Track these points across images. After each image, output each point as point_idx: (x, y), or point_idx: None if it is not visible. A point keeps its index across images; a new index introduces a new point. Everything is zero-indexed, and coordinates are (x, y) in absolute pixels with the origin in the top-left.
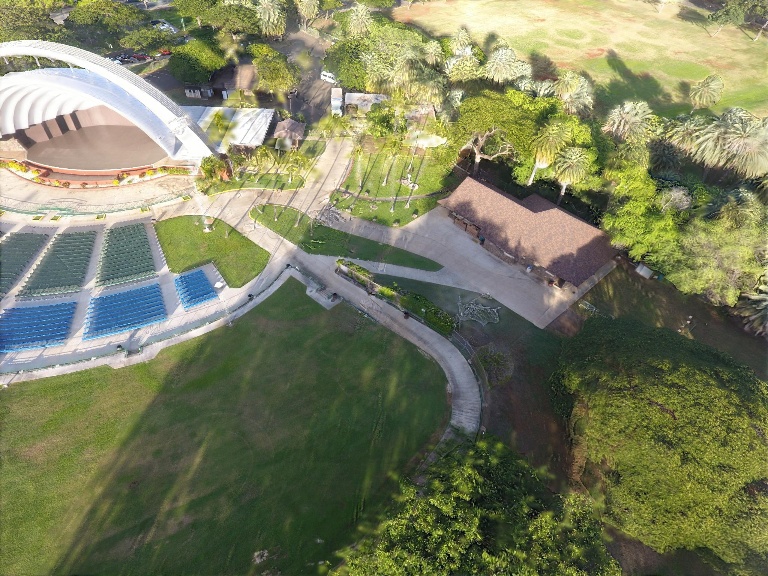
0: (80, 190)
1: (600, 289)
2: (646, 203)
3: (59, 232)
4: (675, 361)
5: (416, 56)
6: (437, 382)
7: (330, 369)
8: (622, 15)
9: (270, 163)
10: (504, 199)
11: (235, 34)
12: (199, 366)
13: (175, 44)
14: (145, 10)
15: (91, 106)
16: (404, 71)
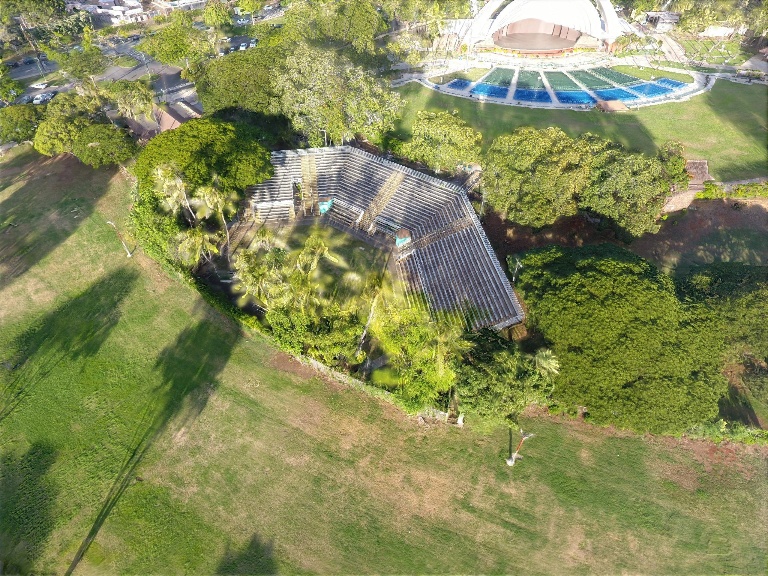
0: (546, 59)
1: None
2: None
3: (565, 72)
4: None
5: None
6: None
7: None
8: None
9: (635, 45)
10: None
11: None
12: (715, 100)
13: None
14: None
15: (518, 20)
16: None
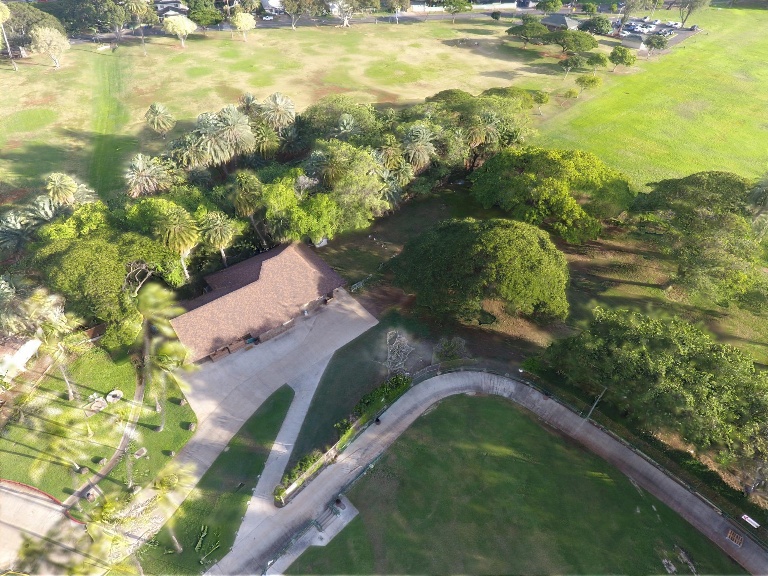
0: None
1: None
2: None
3: None
4: (470, 242)
5: None
6: (465, 402)
7: (454, 507)
8: None
9: None
10: (225, 298)
11: None
12: None
13: None
14: None
15: None
16: None
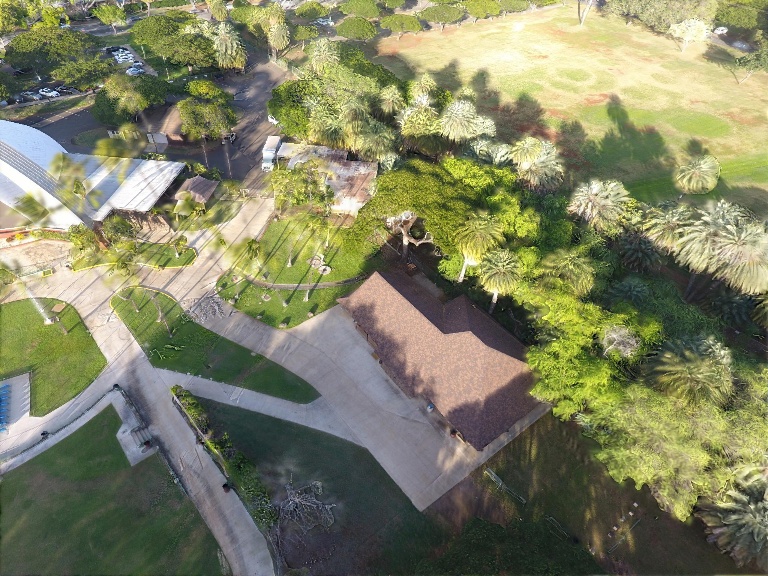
0: None
1: (519, 446)
2: (582, 343)
3: None
4: None
5: (363, 105)
6: None
7: None
8: (638, 53)
9: (165, 229)
10: (411, 309)
11: (191, 65)
12: None
13: (114, 77)
14: (98, 37)
15: None
16: (347, 122)
